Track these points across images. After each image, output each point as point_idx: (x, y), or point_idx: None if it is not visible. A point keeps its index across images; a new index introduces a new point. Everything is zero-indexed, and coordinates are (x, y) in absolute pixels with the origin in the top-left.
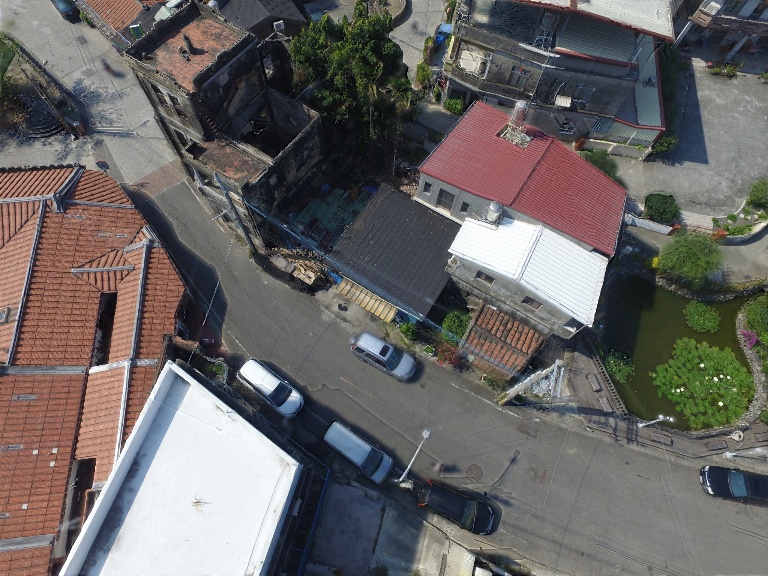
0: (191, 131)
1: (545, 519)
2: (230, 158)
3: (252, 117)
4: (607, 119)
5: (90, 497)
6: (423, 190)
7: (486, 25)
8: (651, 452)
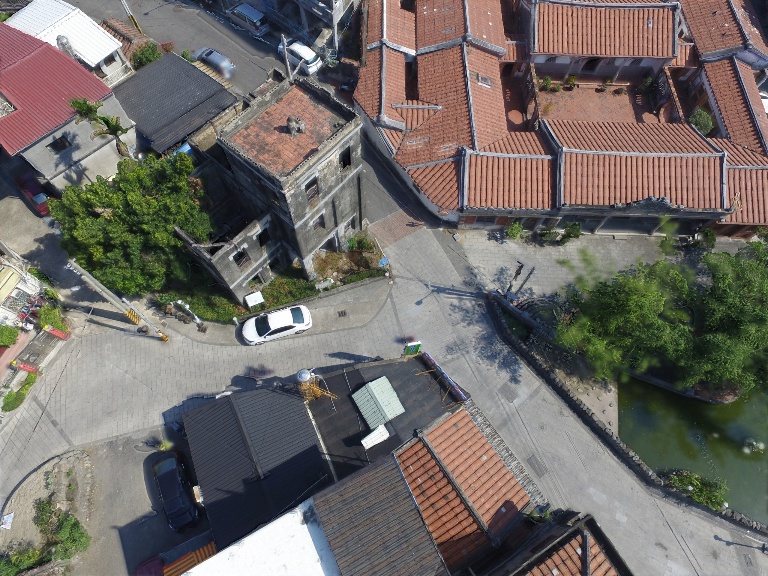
0: None
1: None
2: None
3: None
4: None
5: None
6: None
7: None
8: None
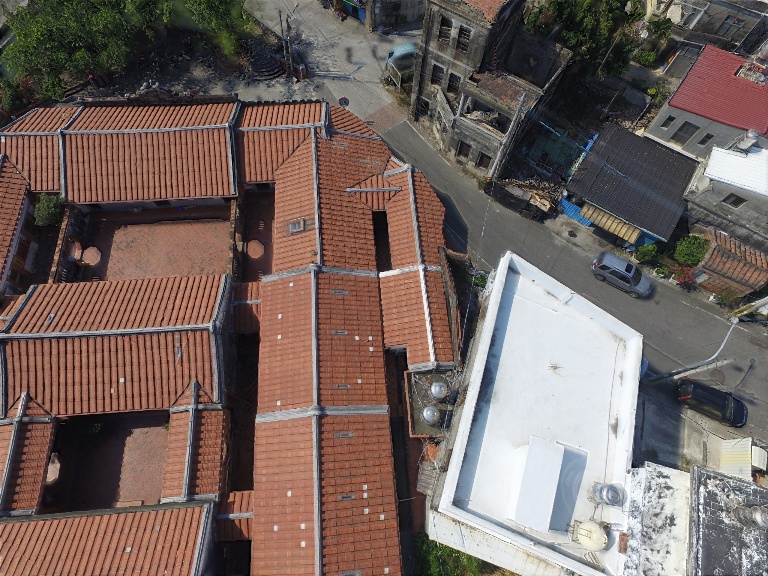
0: (461, 64)
1: None
2: (503, 88)
3: (500, 56)
4: None
5: (408, 377)
6: (661, 125)
7: None
8: None
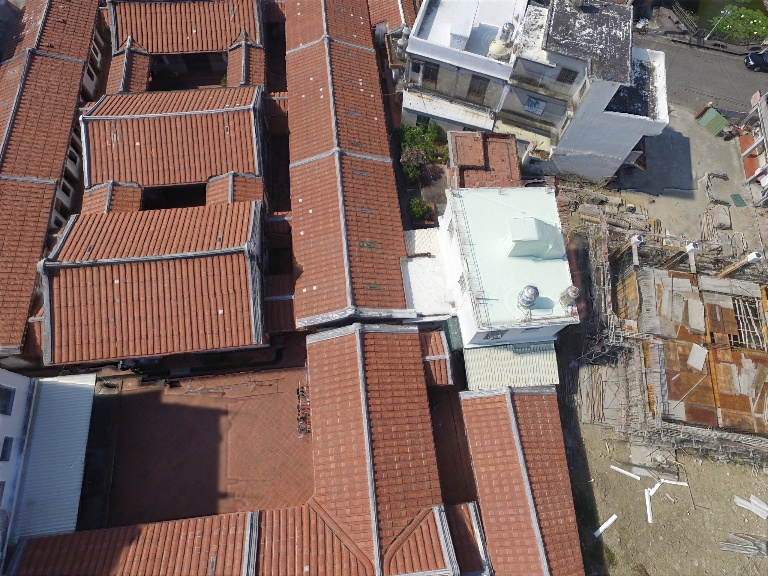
0: None
1: None
2: None
3: None
4: None
5: (387, 39)
6: None
7: None
8: (713, 53)
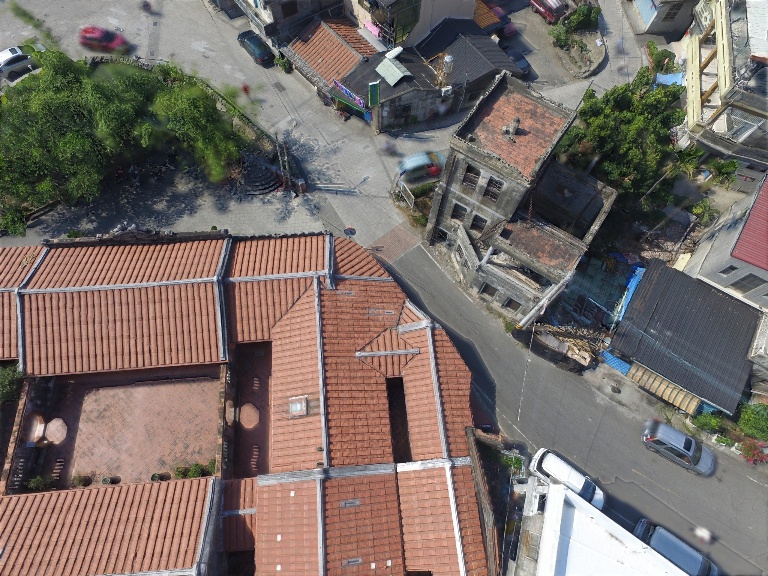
0: (488, 210)
1: None
2: (540, 242)
3: None
4: None
5: None
6: (719, 271)
7: (755, 89)
8: None
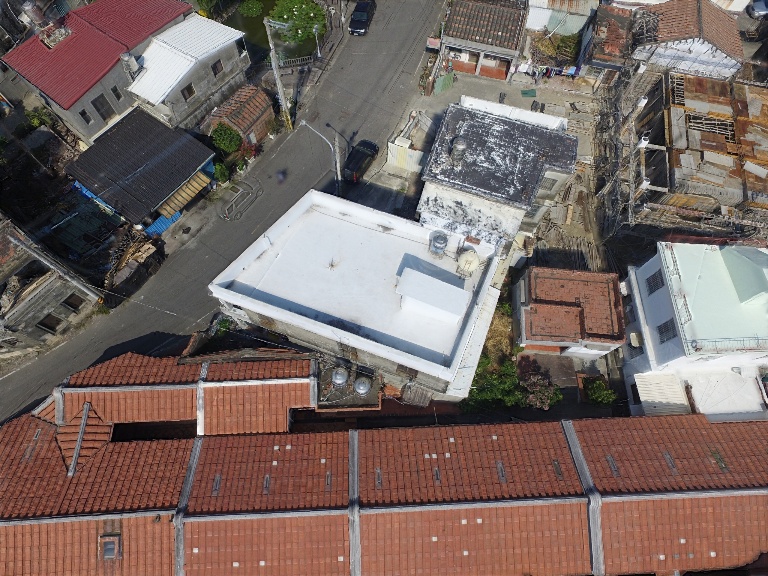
0: None
1: (371, 117)
2: None
3: None
4: (58, 0)
5: None
6: (86, 124)
7: None
8: (337, 56)
